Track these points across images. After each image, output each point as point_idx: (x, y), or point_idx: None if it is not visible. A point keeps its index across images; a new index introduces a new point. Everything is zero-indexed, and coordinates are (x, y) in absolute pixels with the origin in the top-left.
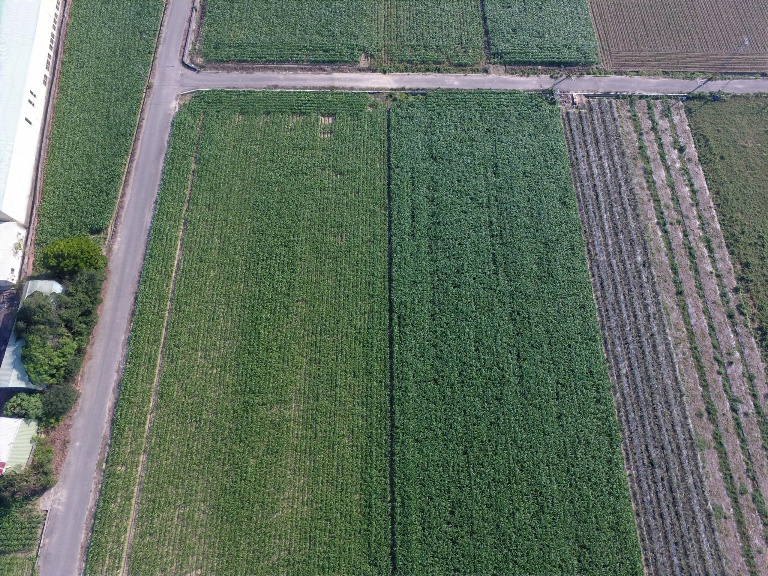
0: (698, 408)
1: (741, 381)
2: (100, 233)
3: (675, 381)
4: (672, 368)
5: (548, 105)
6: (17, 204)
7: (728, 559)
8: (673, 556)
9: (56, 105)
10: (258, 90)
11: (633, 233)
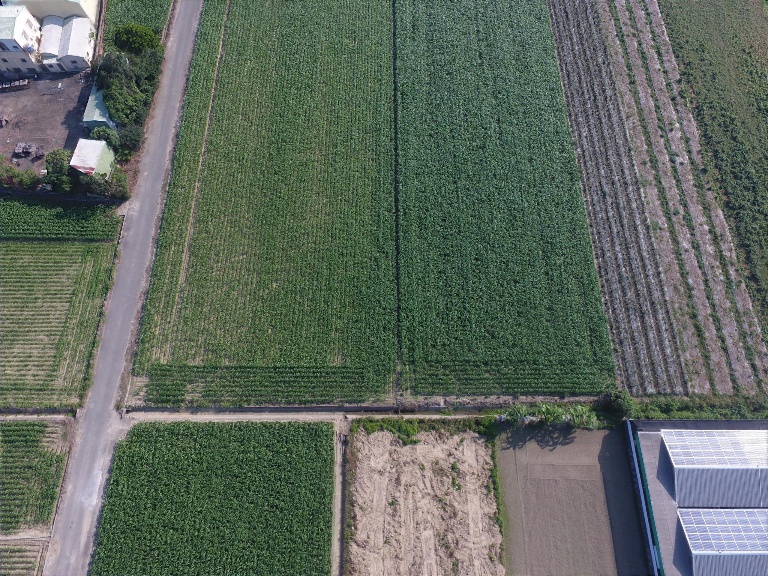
0: (643, 159)
1: (679, 142)
2: (156, 35)
3: (625, 141)
4: (623, 133)
5: None
6: (89, 6)
7: (661, 255)
8: (618, 252)
9: None
10: None
11: (596, 42)
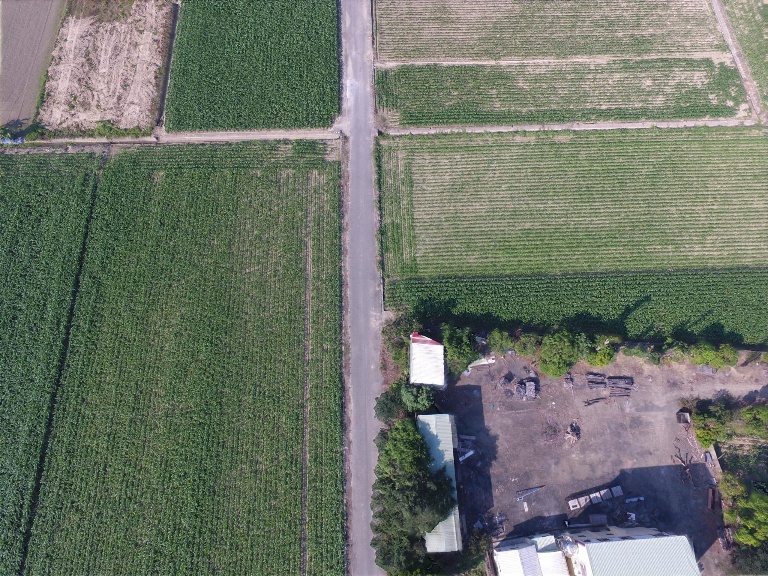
0: None
1: None
2: None
3: None
4: None
5: None
6: None
7: None
8: None
9: None
10: None
11: None
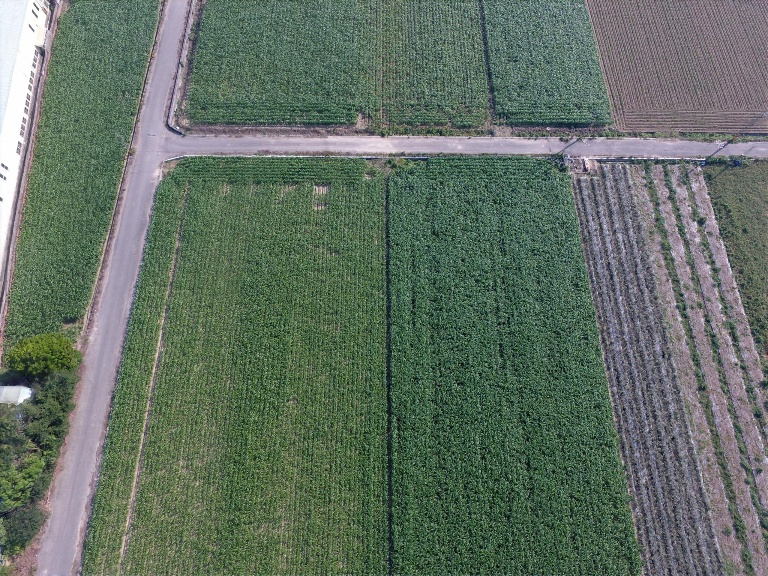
0: (725, 524)
1: None
2: (75, 322)
3: (699, 492)
4: (696, 477)
5: (558, 172)
6: None
7: None
8: None
9: (30, 175)
10: (248, 156)
11: (651, 318)
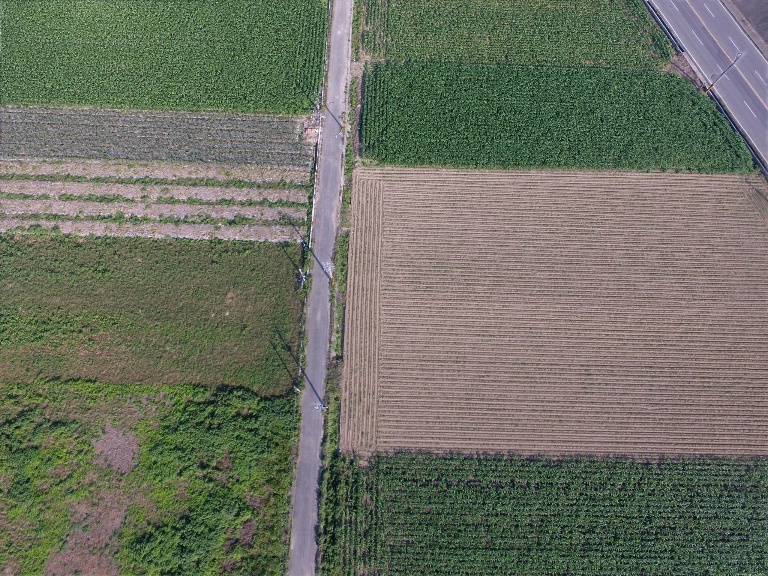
0: None
1: None
2: None
3: None
4: None
5: None
6: None
7: None
8: None
9: None
10: None
11: None
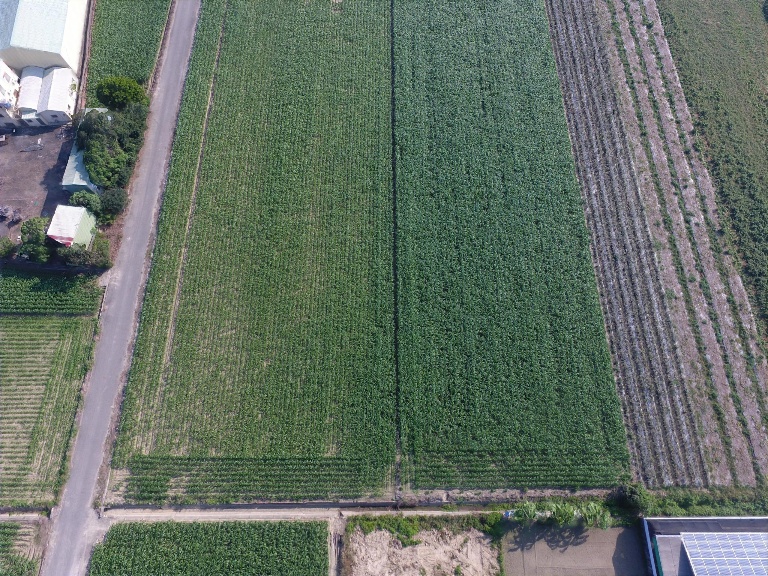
0: (656, 219)
1: (694, 200)
2: (142, 84)
3: (637, 200)
4: (635, 190)
5: None
6: (71, 55)
7: (677, 328)
8: (631, 325)
9: None
10: None
11: (605, 89)
